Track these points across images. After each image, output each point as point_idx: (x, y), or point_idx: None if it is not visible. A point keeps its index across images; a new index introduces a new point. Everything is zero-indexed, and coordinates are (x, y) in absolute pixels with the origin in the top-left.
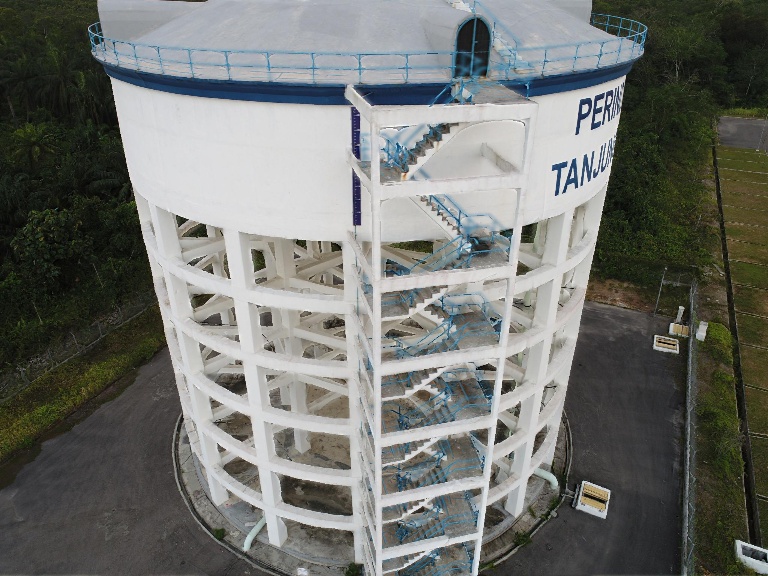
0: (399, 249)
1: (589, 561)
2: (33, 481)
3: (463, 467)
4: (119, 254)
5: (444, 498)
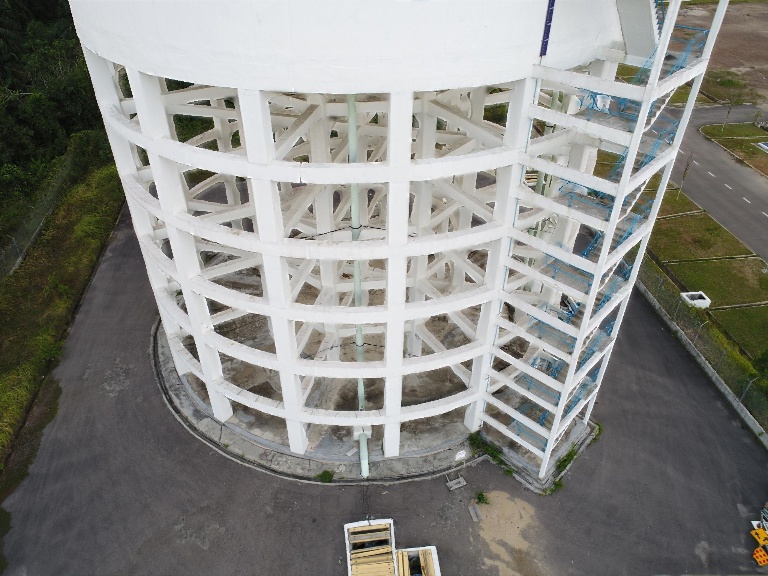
0: (338, 137)
1: (616, 348)
2: (37, 547)
3: (609, 283)
4: None
5: None
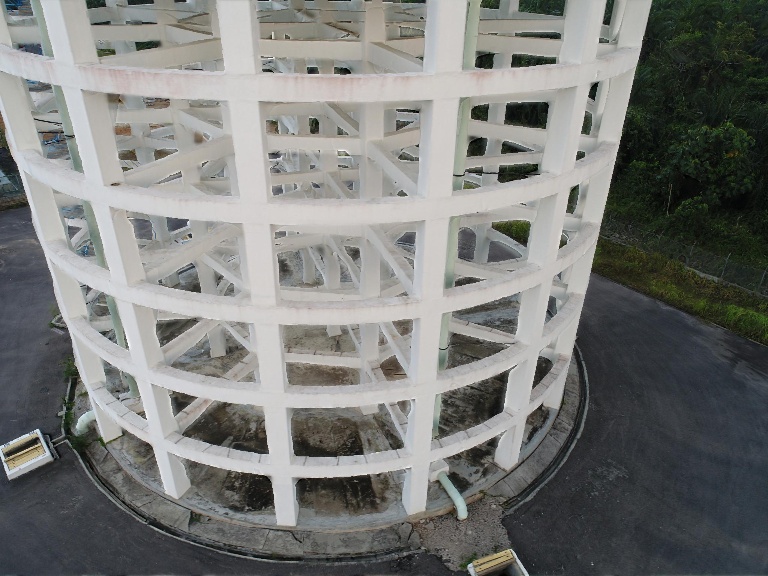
0: None
1: None
2: None
3: None
4: (767, 228)
5: (80, 210)
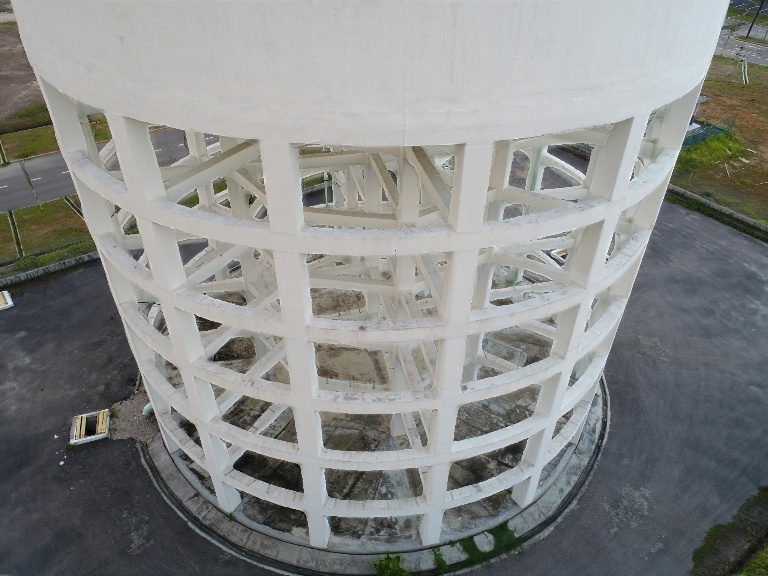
0: None
1: None
2: (767, 426)
3: None
4: None
5: None
